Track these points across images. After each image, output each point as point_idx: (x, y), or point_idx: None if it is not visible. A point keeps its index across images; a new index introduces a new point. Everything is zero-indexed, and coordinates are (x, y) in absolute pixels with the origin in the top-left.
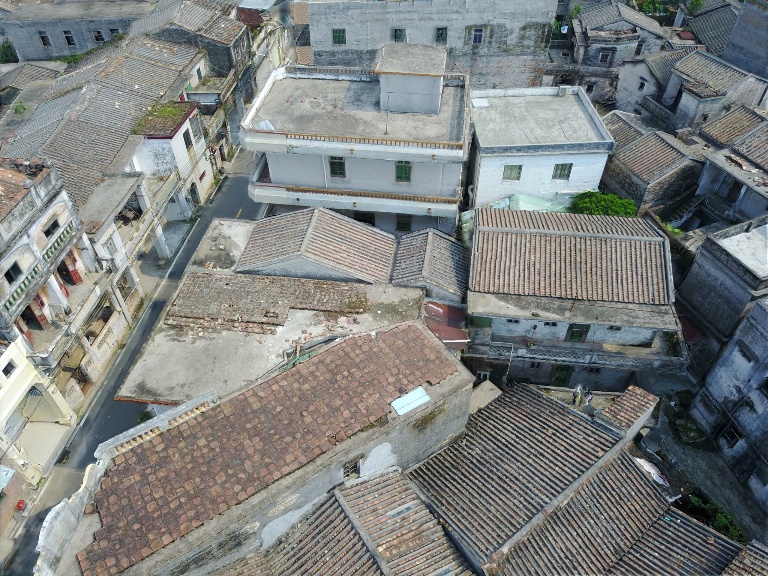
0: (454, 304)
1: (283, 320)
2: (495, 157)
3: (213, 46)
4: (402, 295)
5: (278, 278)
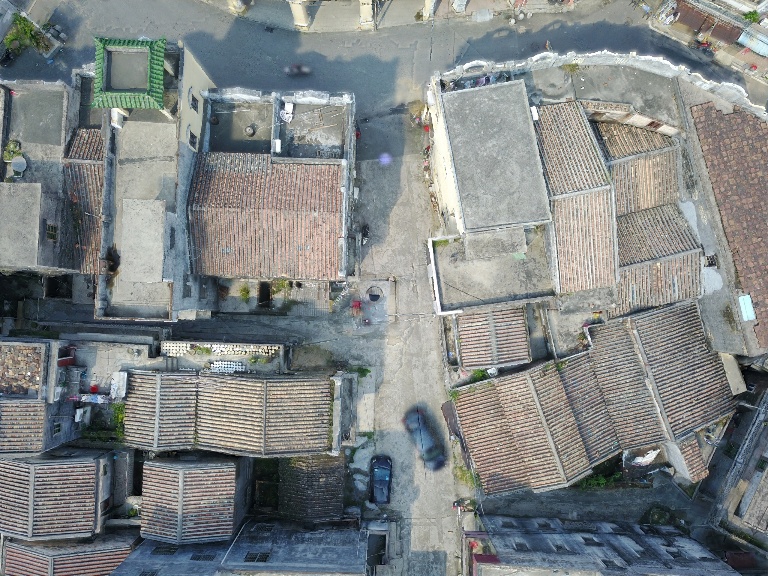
0: None
1: None
2: None
3: None
4: None
5: None
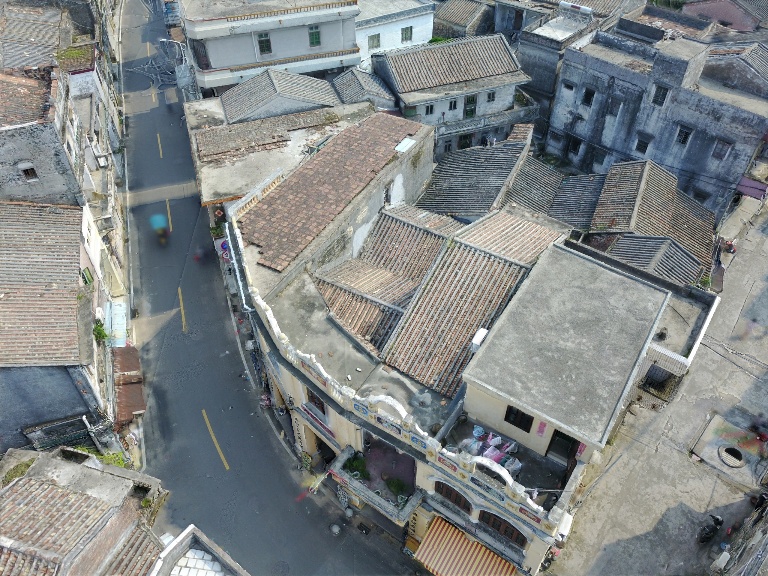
0: (390, 109)
1: (288, 137)
2: (361, 30)
3: (73, 5)
4: (357, 107)
5: (265, 119)
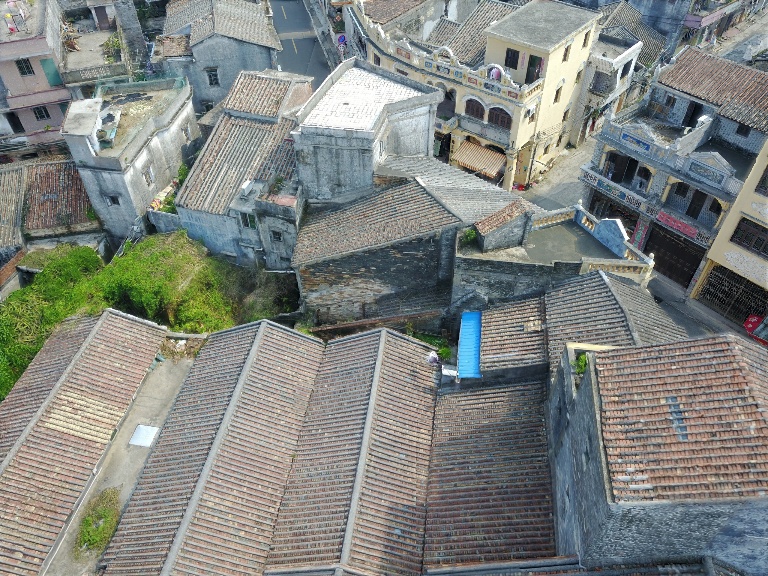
0: None
1: None
2: None
3: None
4: None
5: None
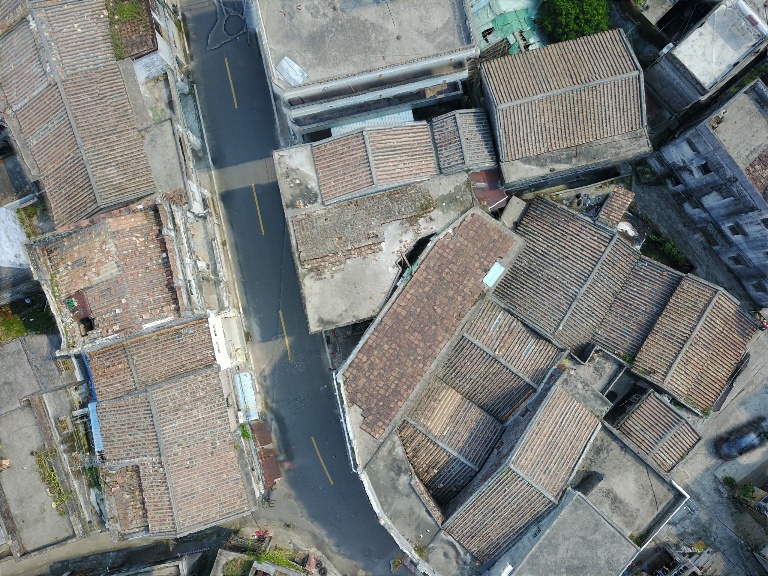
0: (488, 168)
1: (383, 238)
2: None
3: None
4: (454, 182)
5: (360, 200)
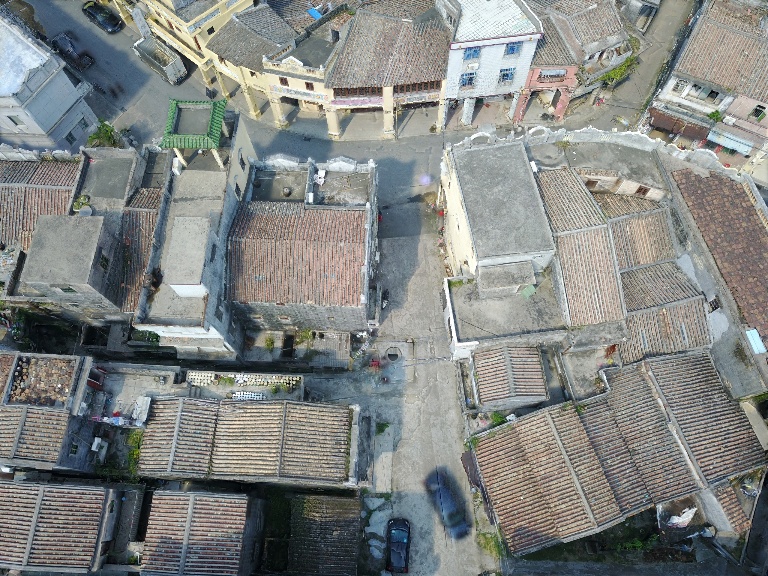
0: None
1: None
2: None
3: None
4: None
5: None
